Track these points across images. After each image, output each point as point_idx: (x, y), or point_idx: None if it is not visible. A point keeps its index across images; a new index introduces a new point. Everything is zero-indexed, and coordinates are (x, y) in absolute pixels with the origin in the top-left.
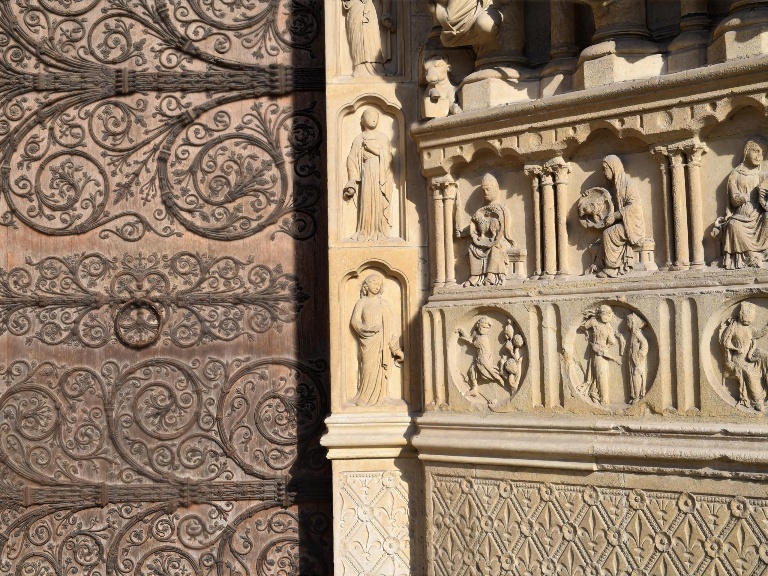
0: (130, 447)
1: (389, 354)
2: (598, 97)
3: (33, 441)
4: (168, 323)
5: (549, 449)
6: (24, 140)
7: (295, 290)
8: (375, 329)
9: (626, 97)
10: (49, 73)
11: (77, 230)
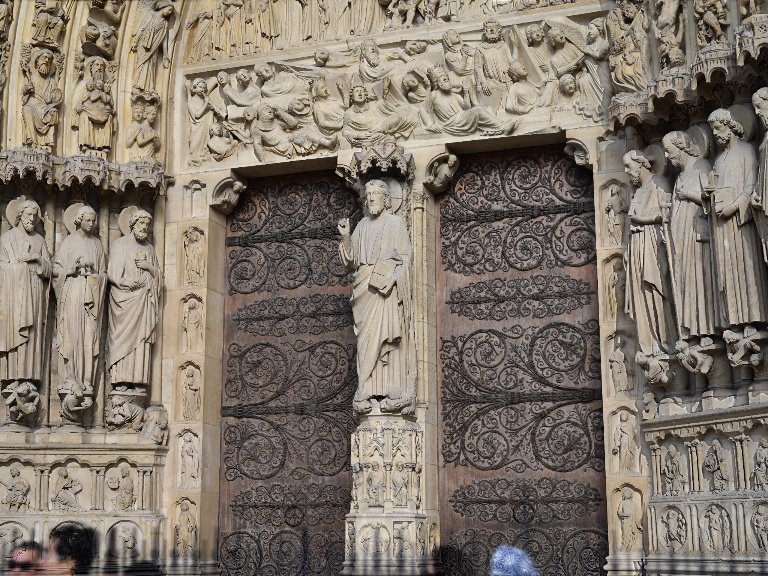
0: (521, 571)
1: (636, 527)
2: (706, 416)
3: (477, 567)
4: (538, 512)
5: (694, 569)
6: (471, 426)
7: (597, 496)
8: (628, 515)
9: (716, 416)
10: (481, 395)
11: (495, 468)
